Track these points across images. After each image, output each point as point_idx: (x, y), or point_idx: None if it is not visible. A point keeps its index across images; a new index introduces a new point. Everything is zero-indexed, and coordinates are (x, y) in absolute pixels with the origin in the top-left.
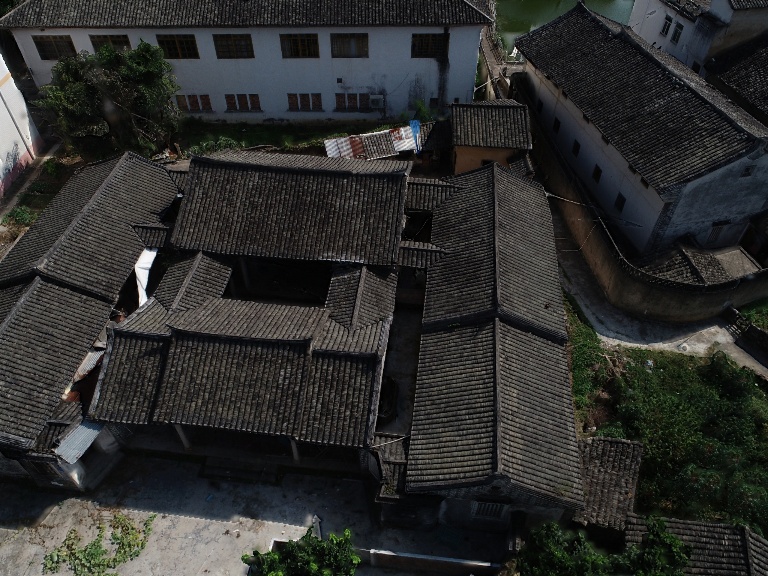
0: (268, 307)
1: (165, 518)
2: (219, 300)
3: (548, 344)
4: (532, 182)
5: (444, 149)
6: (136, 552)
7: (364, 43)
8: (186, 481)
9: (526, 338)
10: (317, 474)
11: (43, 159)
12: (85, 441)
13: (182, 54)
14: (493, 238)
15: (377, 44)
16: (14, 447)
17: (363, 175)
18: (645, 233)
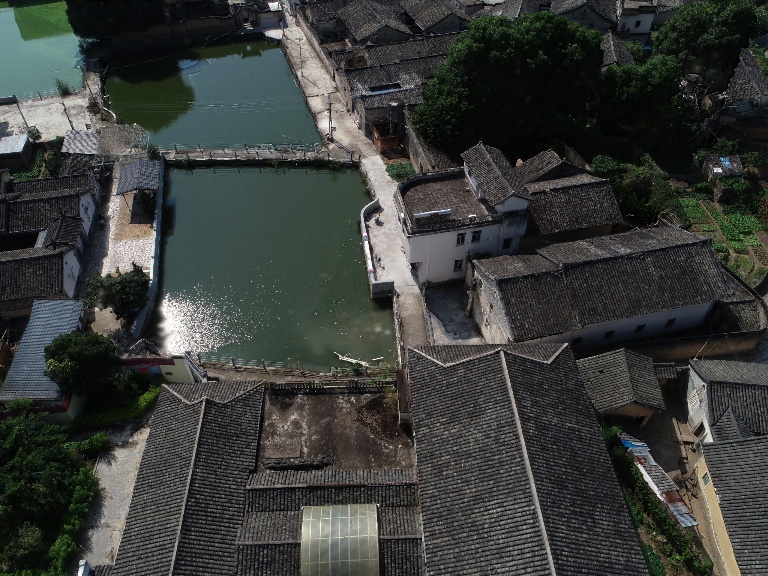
0: None
1: None
2: None
3: None
4: None
5: None
6: None
7: None
8: None
9: None
10: None
11: None
12: None
13: None
14: None
15: None
16: None
17: None
18: (700, 317)
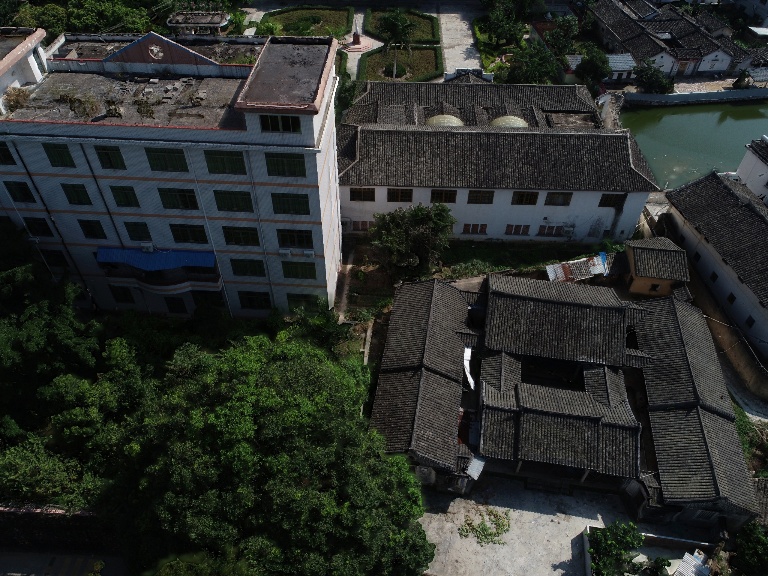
0: (556, 391)
1: (515, 511)
2: (525, 385)
3: (726, 421)
4: (695, 308)
5: (623, 273)
6: (507, 529)
7: (568, 197)
8: (519, 491)
9: (714, 418)
10: (592, 490)
11: (347, 267)
12: (479, 467)
13: (444, 200)
14: (685, 352)
15: (577, 198)
16: (445, 469)
17: (600, 307)
18: None
